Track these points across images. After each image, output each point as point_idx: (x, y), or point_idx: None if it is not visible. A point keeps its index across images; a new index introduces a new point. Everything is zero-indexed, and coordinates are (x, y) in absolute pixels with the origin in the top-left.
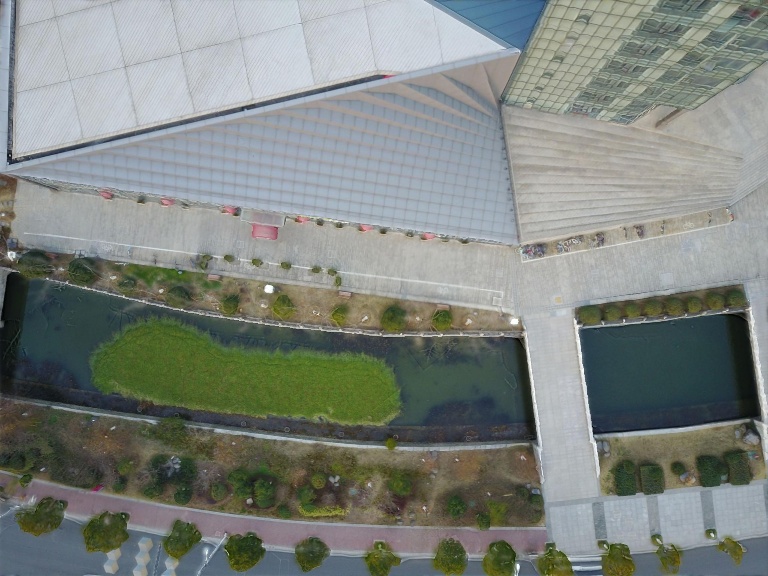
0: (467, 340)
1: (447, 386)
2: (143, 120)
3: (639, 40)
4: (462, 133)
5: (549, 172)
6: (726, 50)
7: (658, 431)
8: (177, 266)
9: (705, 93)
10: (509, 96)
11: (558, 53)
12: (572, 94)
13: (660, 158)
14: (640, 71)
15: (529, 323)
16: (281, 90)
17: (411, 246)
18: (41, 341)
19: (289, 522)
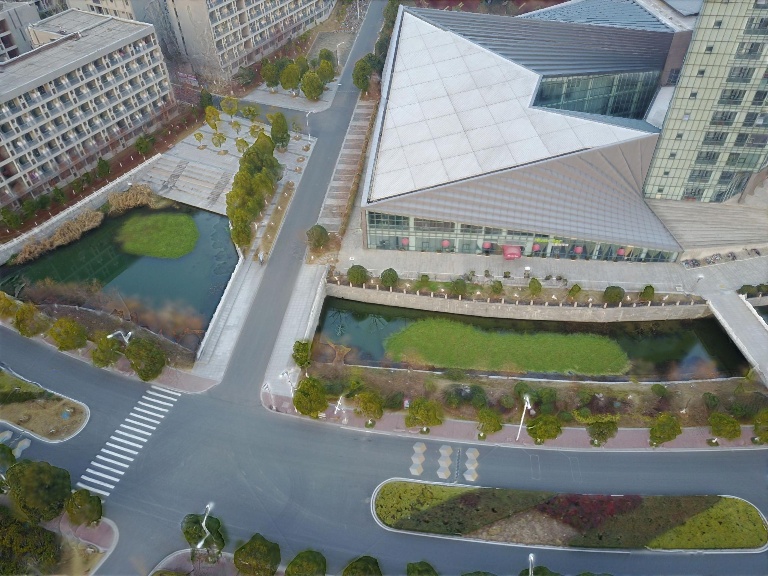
0: (665, 323)
1: (661, 352)
2: (453, 178)
3: (722, 108)
4: (627, 198)
5: (685, 222)
6: (766, 107)
7: None
8: (451, 279)
9: (762, 152)
10: (647, 187)
11: (679, 132)
12: (686, 174)
13: (749, 216)
14: (724, 139)
15: (708, 298)
16: (532, 159)
17: (608, 266)
18: (344, 335)
19: (569, 429)
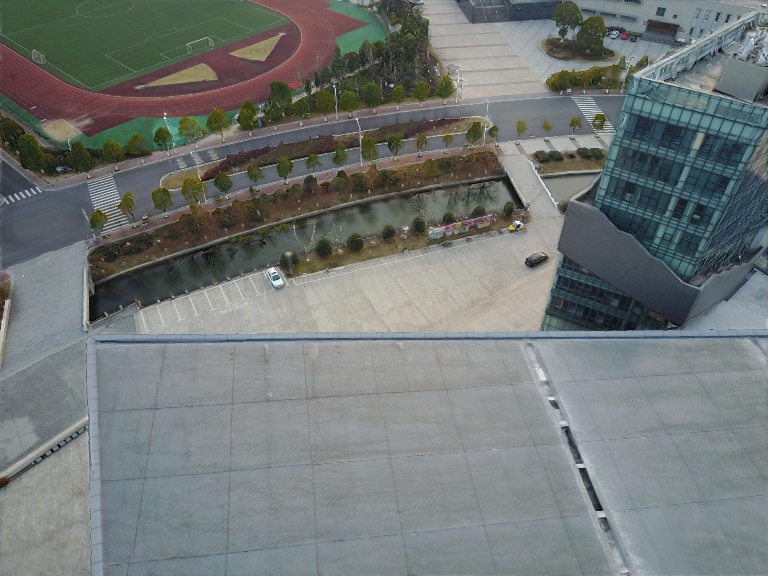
0: None
1: None
2: None
3: None
4: None
5: None
6: None
7: (583, 172)
8: None
9: None
10: None
11: None
12: None
13: None
14: None
15: None
16: None
17: None
18: None
19: None
